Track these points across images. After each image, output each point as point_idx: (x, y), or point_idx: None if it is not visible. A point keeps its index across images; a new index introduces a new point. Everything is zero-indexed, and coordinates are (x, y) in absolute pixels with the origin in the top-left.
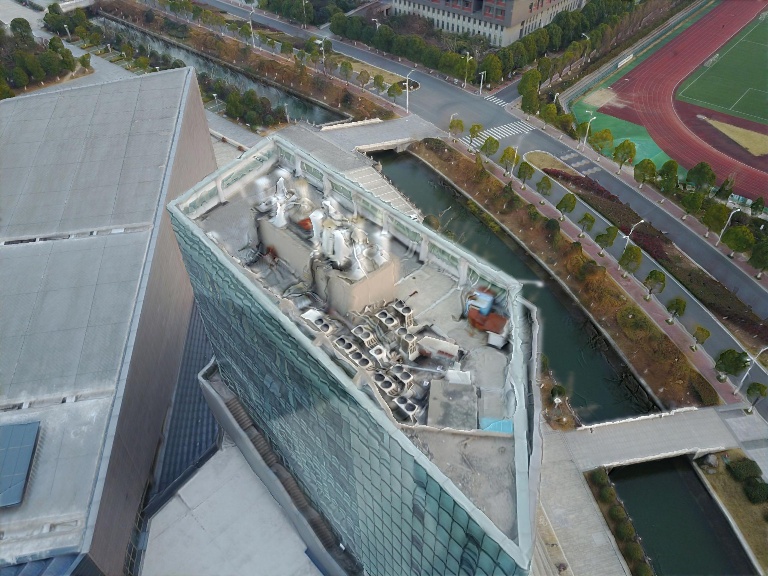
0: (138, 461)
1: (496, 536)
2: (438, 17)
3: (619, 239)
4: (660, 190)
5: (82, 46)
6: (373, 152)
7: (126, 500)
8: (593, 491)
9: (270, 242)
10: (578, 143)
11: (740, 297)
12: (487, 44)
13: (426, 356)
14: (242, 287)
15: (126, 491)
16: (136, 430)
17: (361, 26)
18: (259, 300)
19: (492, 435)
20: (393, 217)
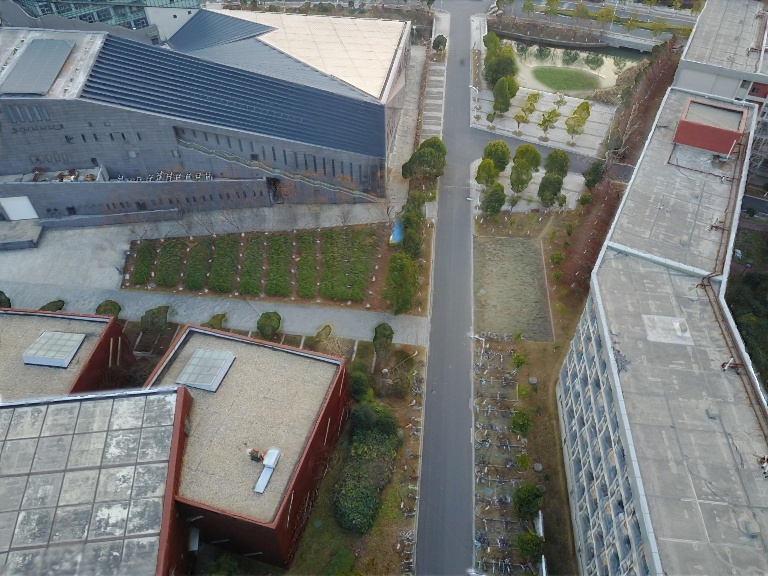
0: None
1: None
2: None
3: None
4: None
5: None
6: None
7: None
8: None
9: None
10: None
11: None
12: None
13: None
14: None
15: None
16: None
17: None
18: None
19: None
20: None
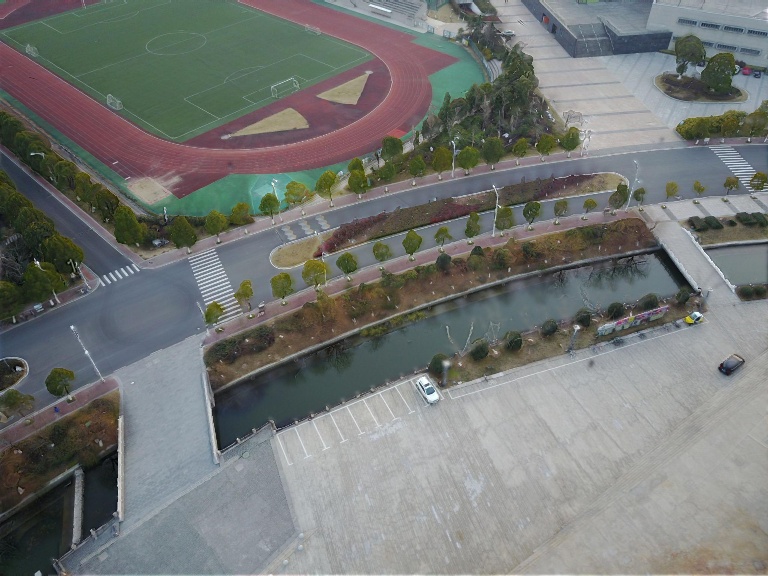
0: None
1: None
2: None
3: (447, 227)
4: (368, 186)
5: None
6: (216, 436)
7: None
8: (757, 299)
9: None
10: (271, 219)
11: (520, 182)
12: None
13: None
14: None
15: None
16: None
17: None
18: None
19: None
20: None
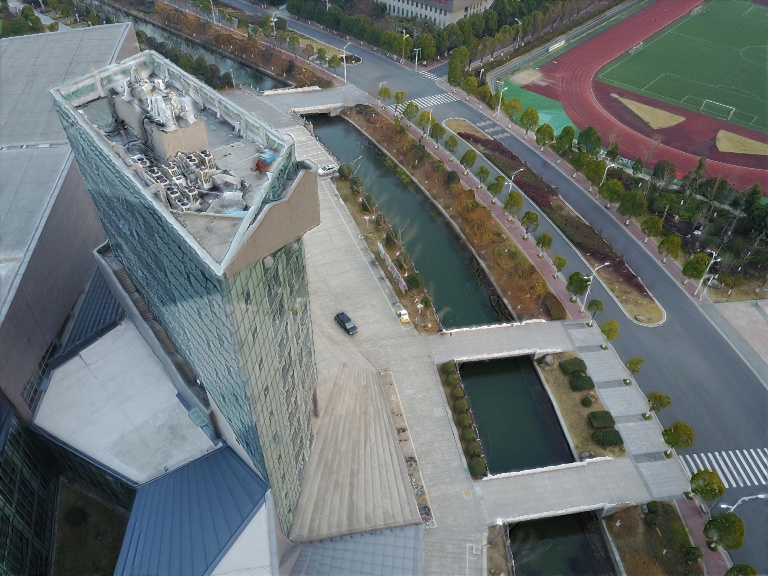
0: (43, 320)
1: (208, 260)
2: (390, 2)
3: None
4: (559, 153)
5: (54, 17)
6: (308, 115)
7: (28, 343)
8: (442, 378)
9: (123, 115)
10: (494, 112)
11: (606, 239)
12: (432, 27)
13: (217, 186)
14: (90, 137)
15: (28, 336)
16: (42, 294)
17: (314, 6)
18: (99, 144)
19: (232, 216)
20: (221, 102)
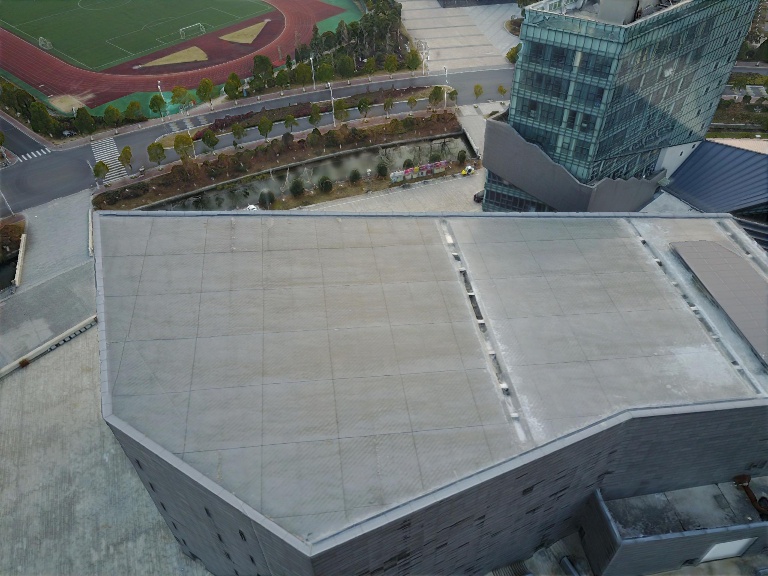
0: None
1: None
2: None
3: (300, 121)
4: (244, 96)
5: None
6: None
7: None
8: None
9: None
10: (160, 117)
11: None
12: None
13: None
14: None
15: None
16: None
17: None
18: (692, 0)
19: None
20: None
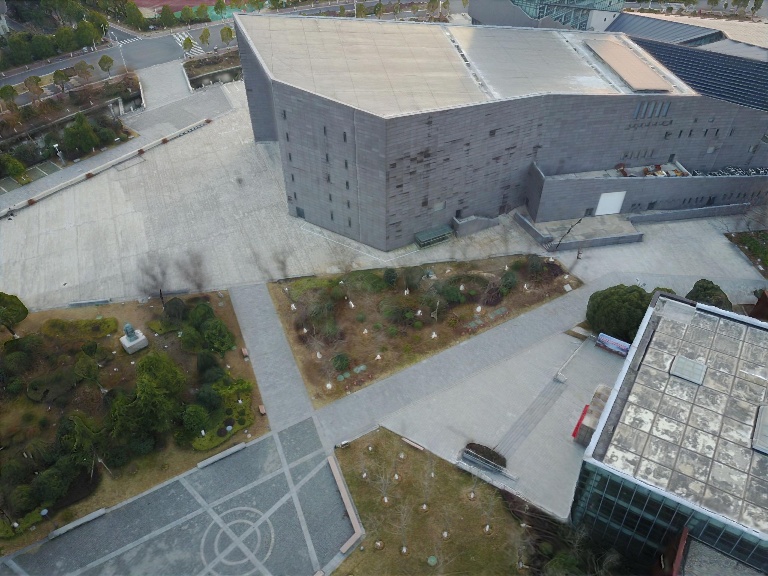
0: None
1: None
2: None
3: None
4: (284, 7)
5: None
6: None
7: None
8: None
9: None
10: (222, 18)
11: None
12: None
13: None
14: None
15: None
16: None
17: None
18: None
19: None
20: None
